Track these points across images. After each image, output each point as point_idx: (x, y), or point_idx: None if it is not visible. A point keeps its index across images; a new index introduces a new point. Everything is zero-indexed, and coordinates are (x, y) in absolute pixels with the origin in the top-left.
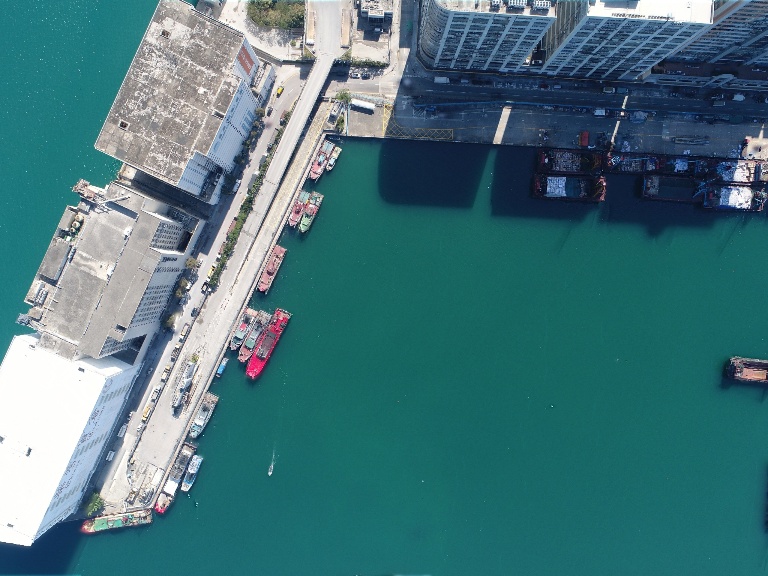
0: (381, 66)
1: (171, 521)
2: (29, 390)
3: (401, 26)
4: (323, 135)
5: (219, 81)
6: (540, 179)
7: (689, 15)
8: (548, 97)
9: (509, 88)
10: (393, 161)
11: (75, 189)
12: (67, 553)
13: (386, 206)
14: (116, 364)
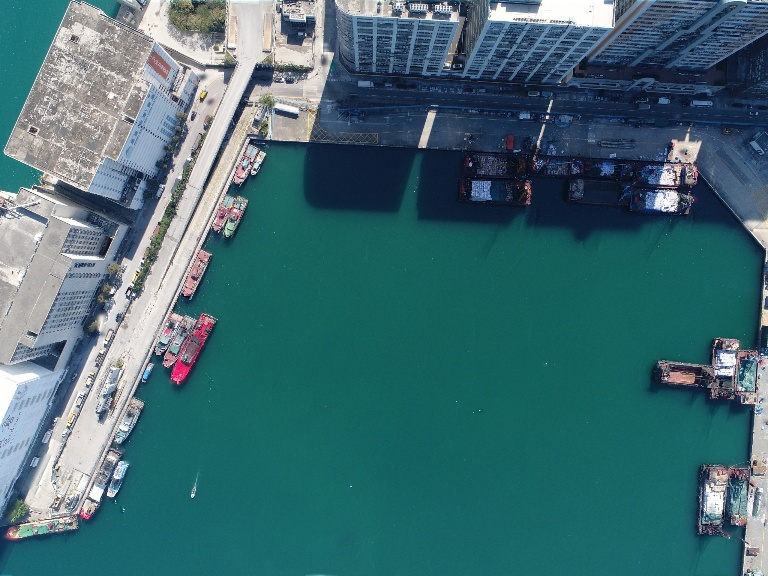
0: (304, 70)
1: (98, 527)
2: None
3: (325, 30)
4: (247, 139)
5: (129, 86)
6: (465, 183)
7: (591, 19)
8: (473, 101)
9: (434, 92)
10: (318, 165)
11: None
12: None
13: (312, 210)
14: (34, 370)
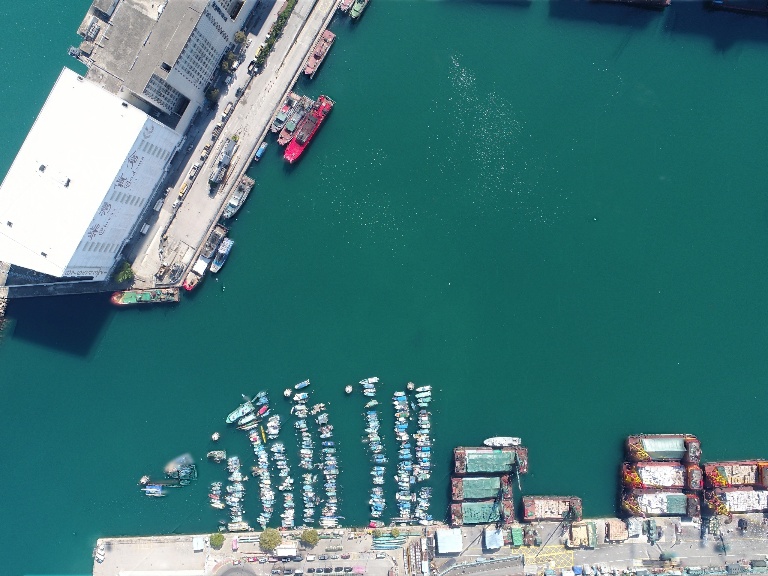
0: None
1: (197, 303)
2: (73, 121)
3: None
4: None
5: None
6: None
7: None
8: None
9: None
10: None
11: None
12: (95, 325)
13: None
14: None
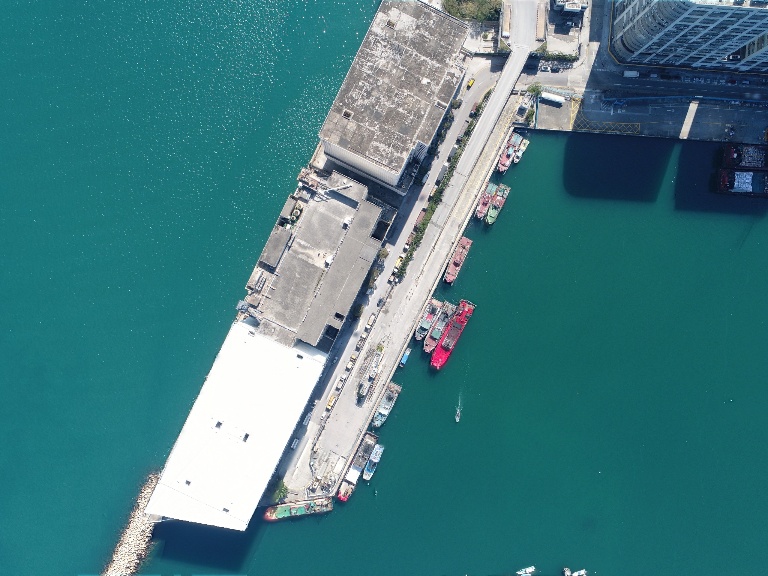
0: (572, 60)
1: (350, 509)
2: (248, 376)
3: (591, 20)
4: (512, 128)
5: (443, 72)
6: (728, 174)
7: None
8: (735, 92)
9: (697, 83)
10: (578, 154)
11: (300, 177)
12: (247, 540)
13: (570, 199)
14: (317, 352)
